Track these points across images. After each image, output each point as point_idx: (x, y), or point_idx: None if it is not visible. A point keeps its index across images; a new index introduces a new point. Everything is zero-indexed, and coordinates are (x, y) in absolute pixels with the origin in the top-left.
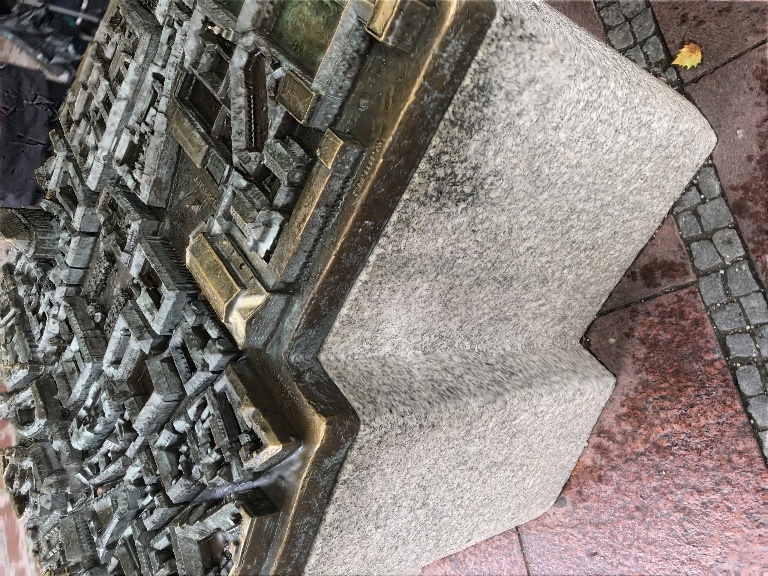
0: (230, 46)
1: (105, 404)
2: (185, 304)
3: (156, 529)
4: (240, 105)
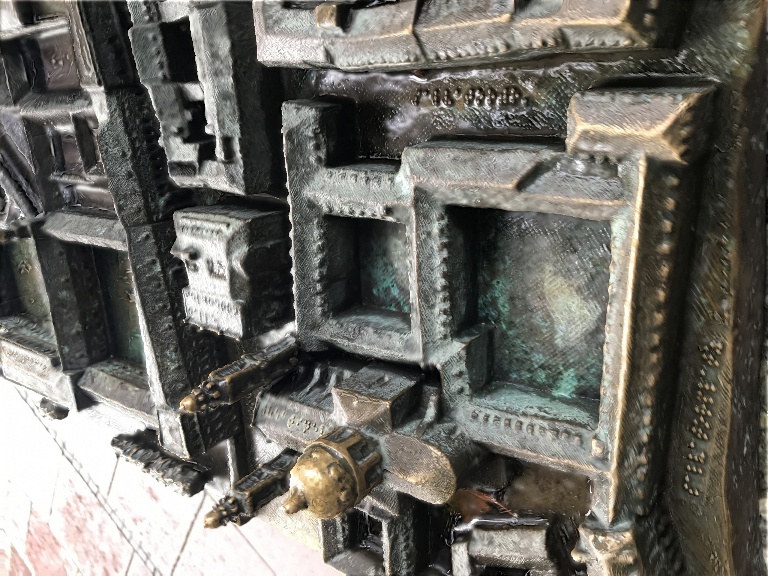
0: (78, 196)
1: None
2: None
3: None
4: None
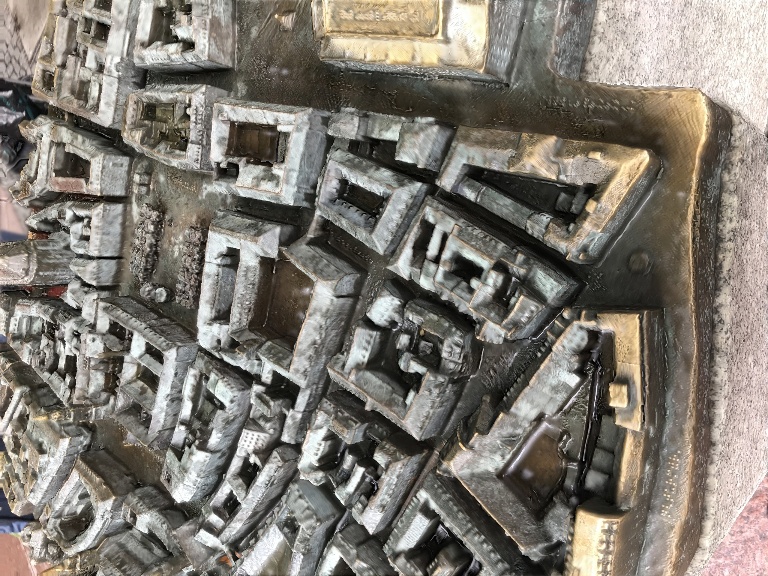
0: None
1: (219, 387)
2: (331, 116)
3: (375, 538)
4: None
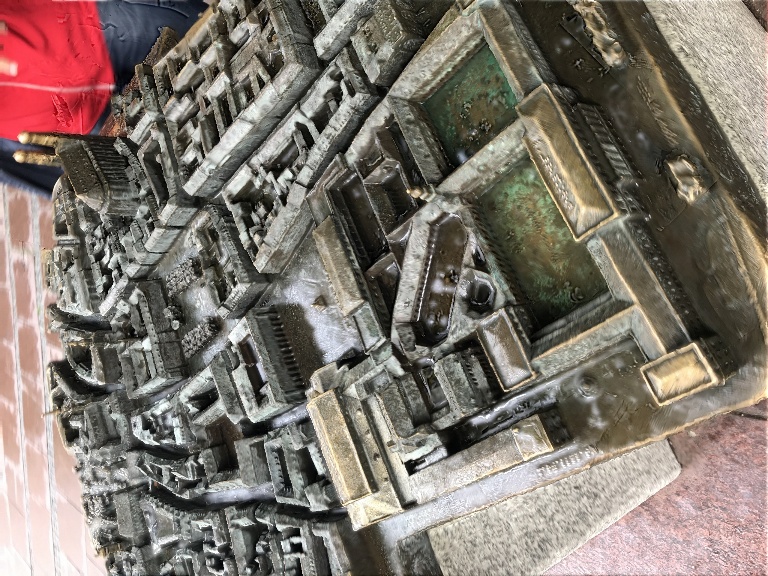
0: (418, 179)
1: (177, 431)
2: (293, 424)
3: None
4: (415, 269)
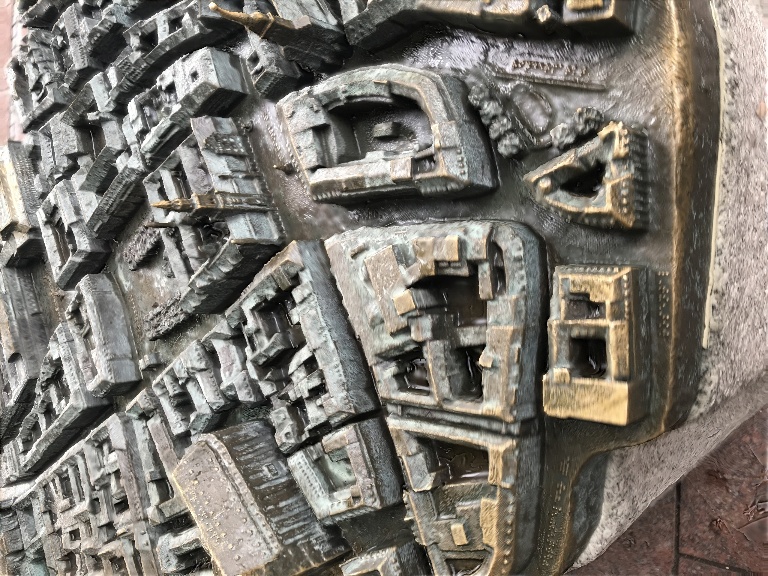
0: None
1: (131, 116)
2: (38, 196)
3: None
4: None
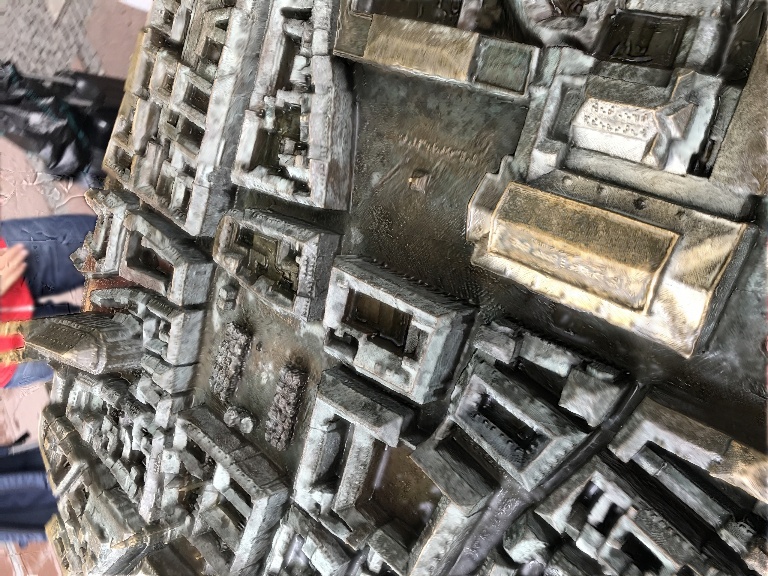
0: None
1: (318, 557)
2: (480, 329)
3: None
4: None
